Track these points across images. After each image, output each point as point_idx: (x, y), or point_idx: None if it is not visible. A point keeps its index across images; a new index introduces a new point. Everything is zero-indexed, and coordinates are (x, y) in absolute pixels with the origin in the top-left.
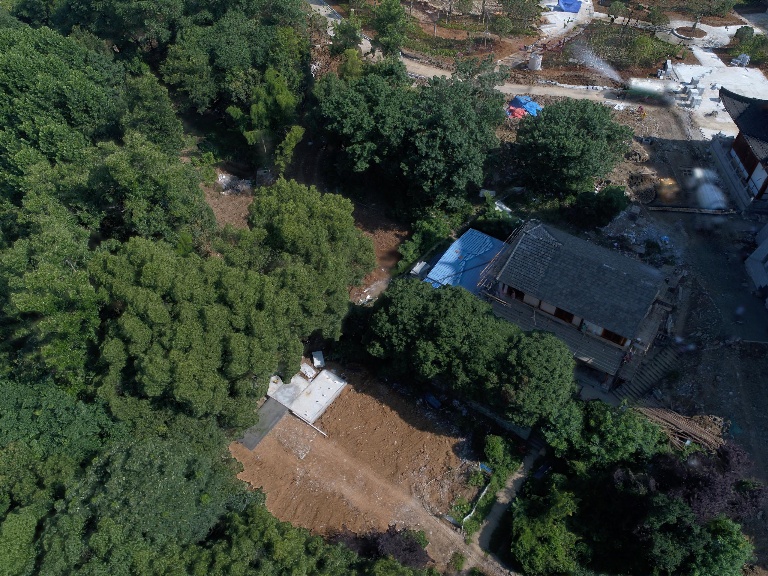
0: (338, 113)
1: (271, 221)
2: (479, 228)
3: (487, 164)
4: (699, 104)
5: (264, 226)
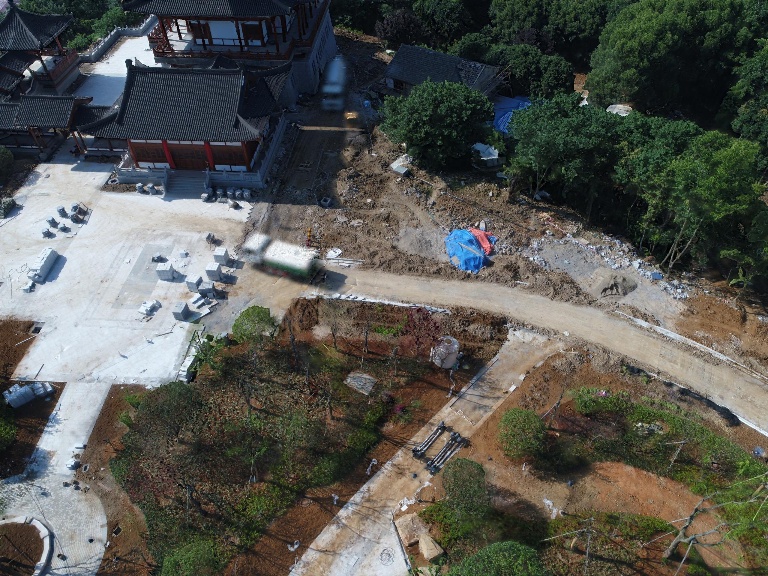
0: None
1: None
2: None
3: None
4: None
5: None
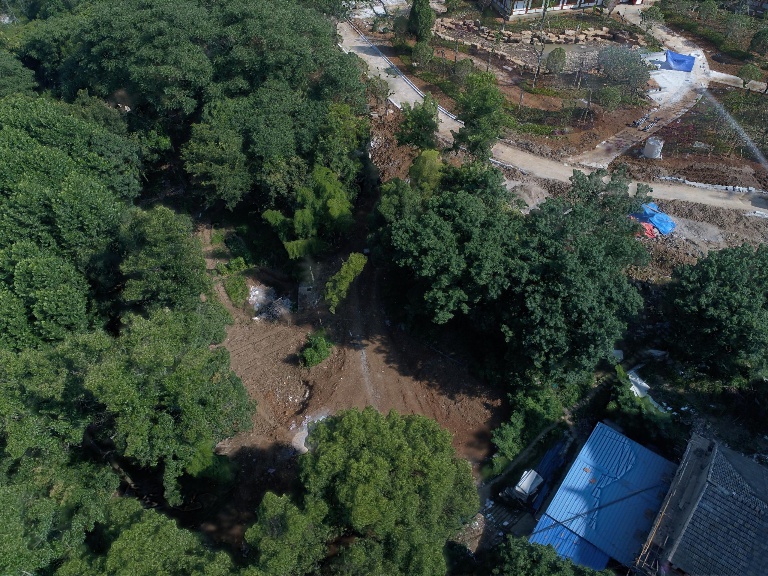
0: (415, 247)
1: (334, 488)
2: (606, 414)
3: None
4: None
5: (323, 494)
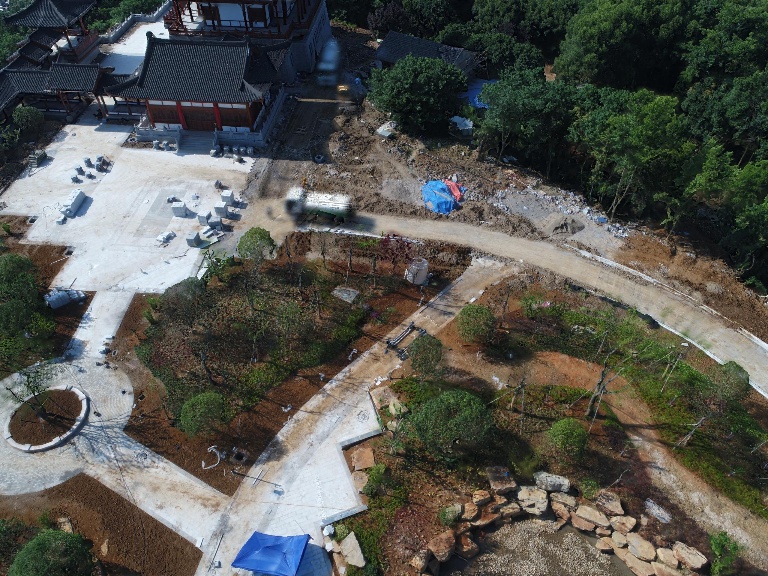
0: None
1: None
2: None
3: None
4: None
5: None
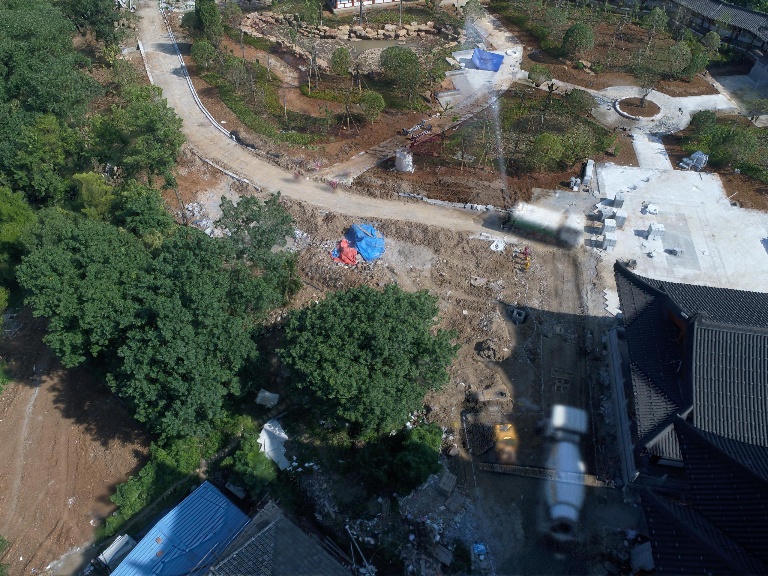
0: (33, 284)
1: None
2: None
3: (249, 371)
4: (613, 245)
5: None
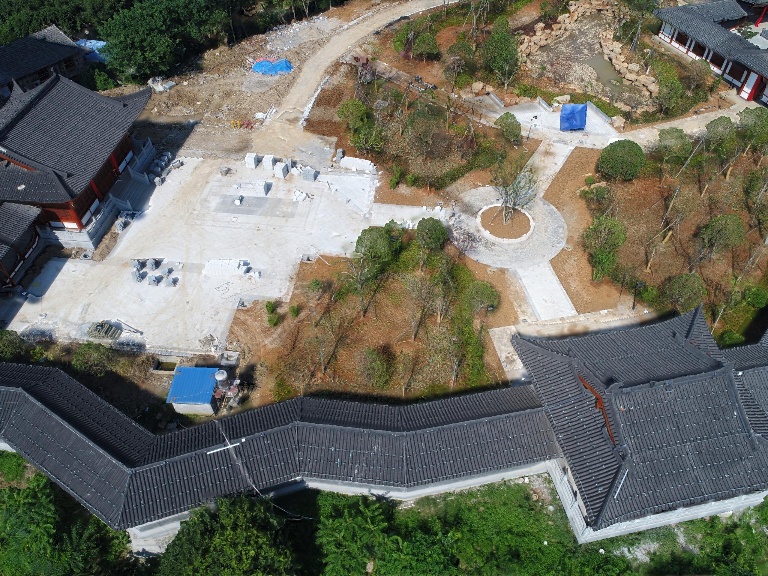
0: None
1: None
2: None
3: None
4: (246, 162)
5: None
